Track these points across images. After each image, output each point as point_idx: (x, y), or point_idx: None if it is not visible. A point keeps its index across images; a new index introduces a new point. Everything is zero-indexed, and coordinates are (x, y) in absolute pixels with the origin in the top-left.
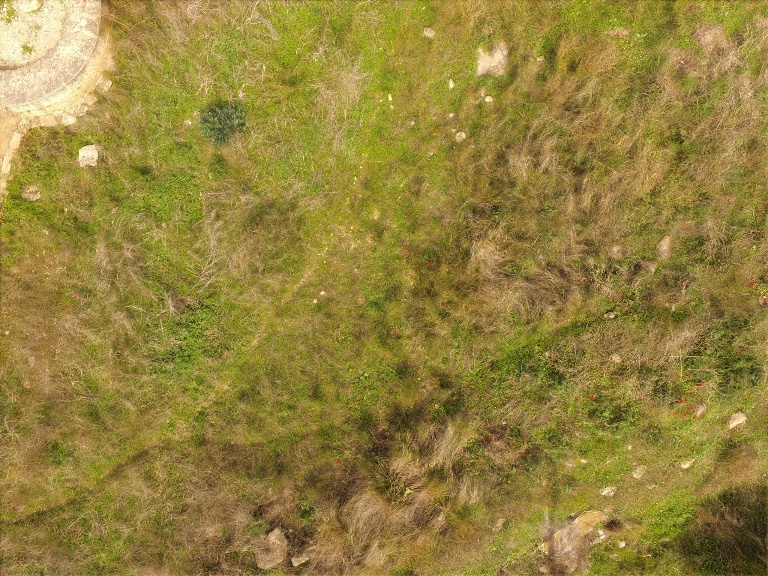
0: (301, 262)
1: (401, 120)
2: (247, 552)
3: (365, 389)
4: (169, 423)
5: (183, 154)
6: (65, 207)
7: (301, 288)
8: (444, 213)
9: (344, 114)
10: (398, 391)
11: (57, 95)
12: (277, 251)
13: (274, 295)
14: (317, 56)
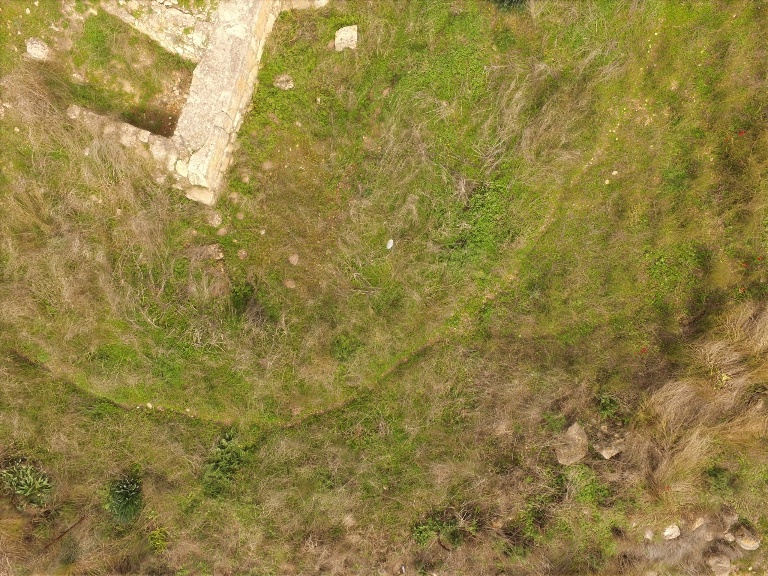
0: (592, 139)
1: None
2: (547, 448)
3: (662, 275)
4: (454, 316)
5: (467, 24)
6: (318, 97)
7: (591, 168)
8: (749, 80)
9: None
10: (697, 276)
11: None
12: (572, 126)
13: (565, 175)
14: None
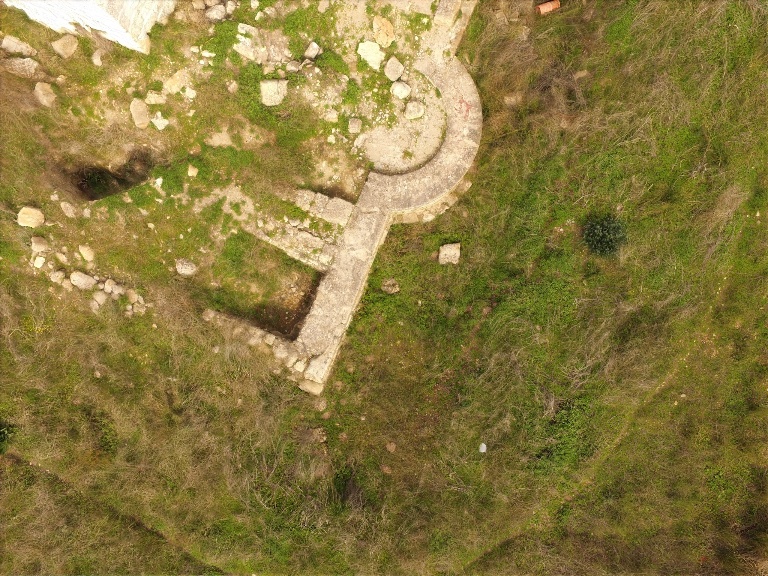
0: (666, 366)
1: (767, 235)
2: None
3: (719, 487)
4: (535, 514)
5: (563, 262)
6: (419, 300)
7: (663, 390)
8: None
9: (719, 230)
10: (751, 490)
11: (436, 199)
12: None
13: (640, 397)
14: (696, 174)
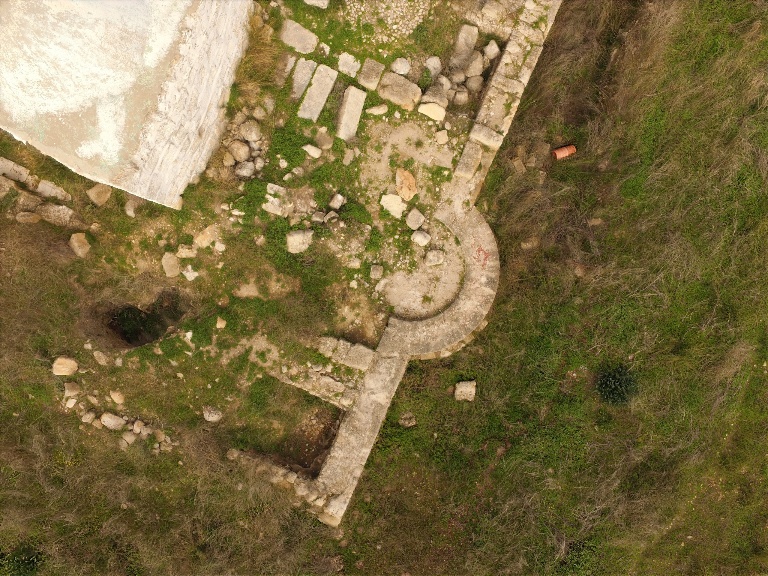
0: (673, 509)
1: None
2: None
3: None
4: None
5: (576, 409)
6: (435, 432)
7: (670, 531)
8: None
9: (727, 381)
10: None
11: None
12: None
13: (648, 539)
14: (706, 327)
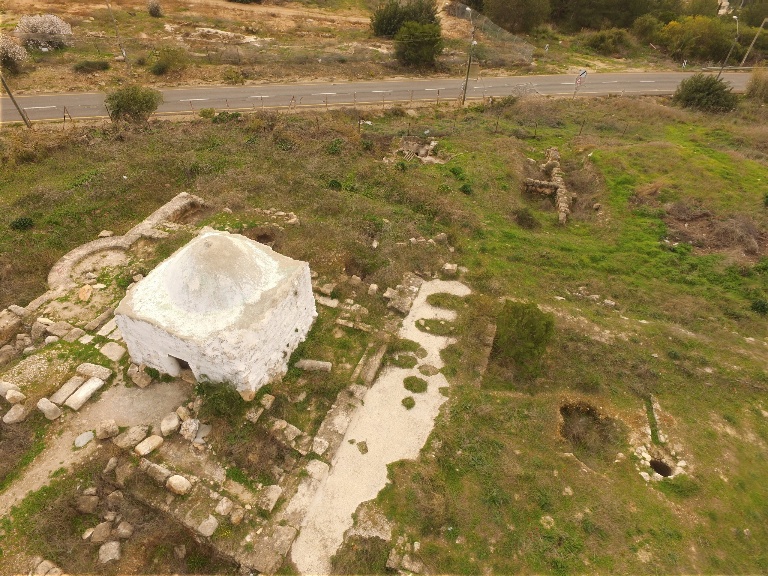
0: None
1: None
2: None
3: None
4: None
5: None
6: None
7: None
8: None
9: None
10: (19, 169)
11: None
12: None
13: None
14: None
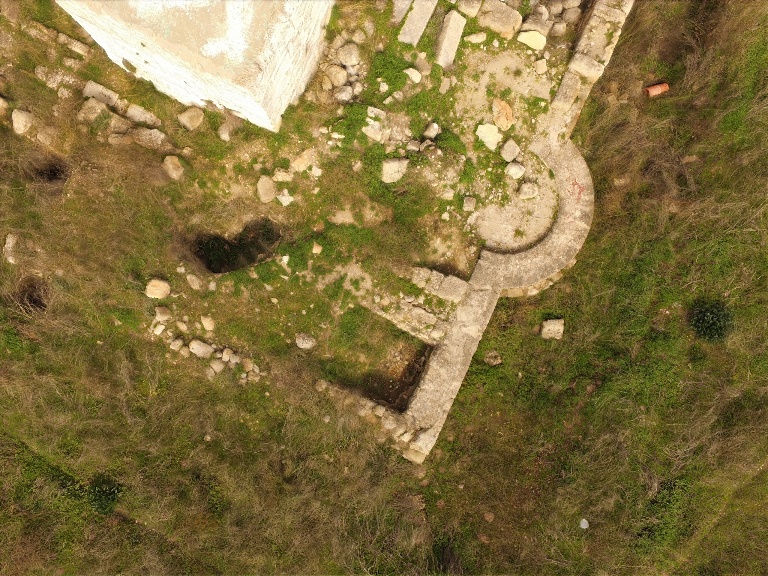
0: (765, 450)
1: None
2: None
3: None
4: None
5: (670, 346)
6: (520, 372)
7: (761, 473)
8: None
9: None
10: None
11: None
12: None
13: (740, 479)
14: None
